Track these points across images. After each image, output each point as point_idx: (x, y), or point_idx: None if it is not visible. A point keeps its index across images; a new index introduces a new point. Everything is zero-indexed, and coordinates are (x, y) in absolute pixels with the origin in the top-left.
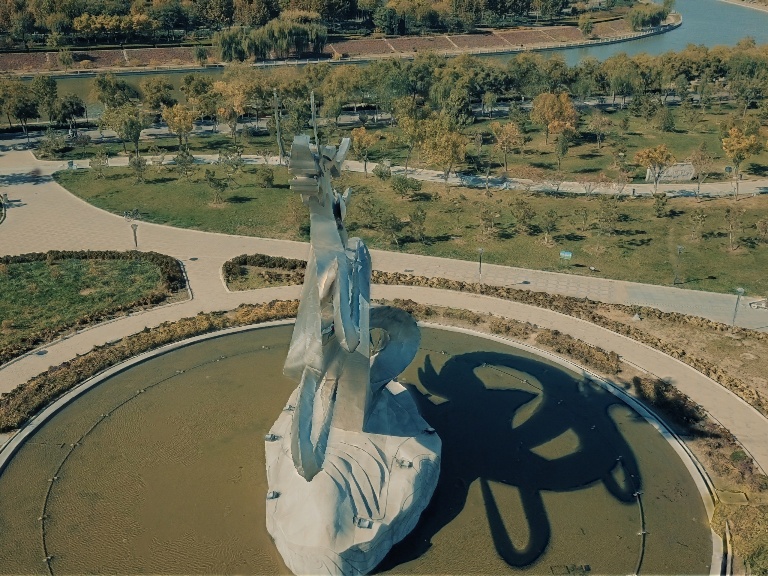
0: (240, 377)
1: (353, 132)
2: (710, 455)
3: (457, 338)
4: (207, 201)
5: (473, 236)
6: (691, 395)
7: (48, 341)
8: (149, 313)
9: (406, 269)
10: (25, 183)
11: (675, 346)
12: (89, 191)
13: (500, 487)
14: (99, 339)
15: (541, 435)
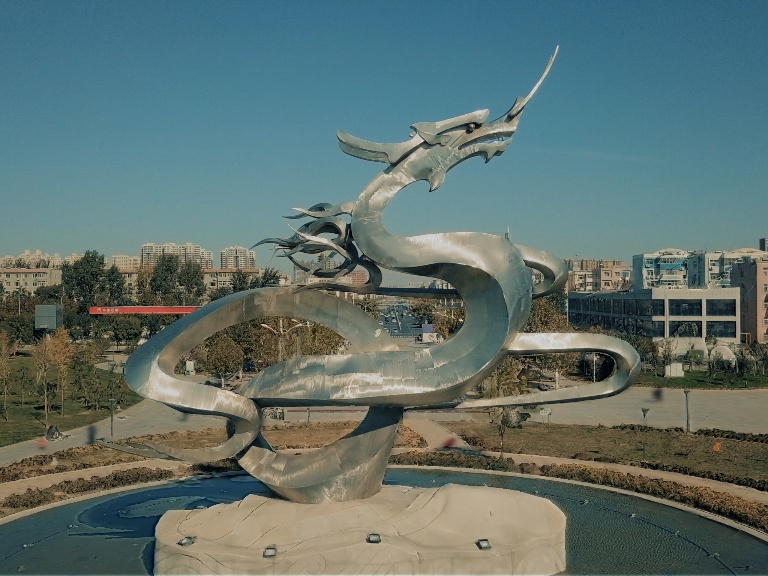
0: None
1: None
2: None
3: (31, 522)
4: None
5: None
6: None
7: None
8: None
9: None
10: None
11: None
12: None
13: None
14: None
15: None
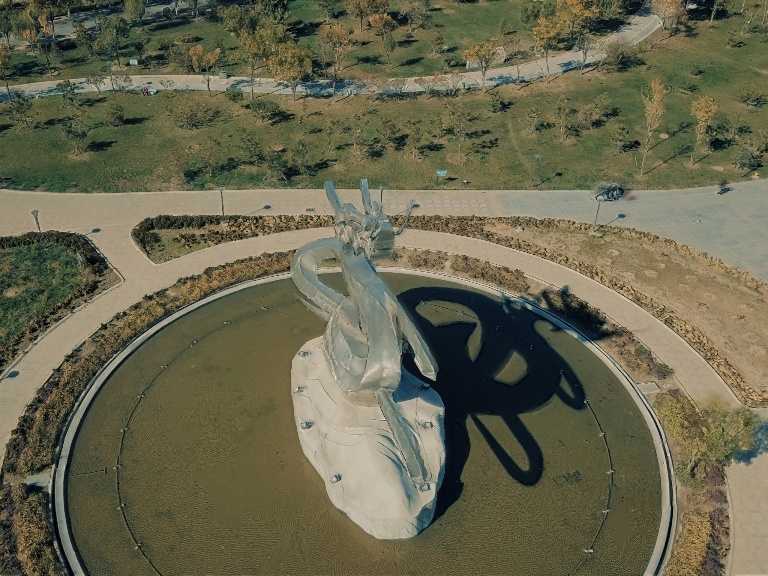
0: (222, 360)
1: (191, 52)
2: (622, 354)
3: (387, 278)
4: (66, 153)
5: (348, 159)
6: (588, 300)
7: (10, 359)
8: (92, 305)
9: (307, 208)
10: None
11: (558, 253)
12: None
13: (488, 419)
14: (62, 346)
15: (495, 363)
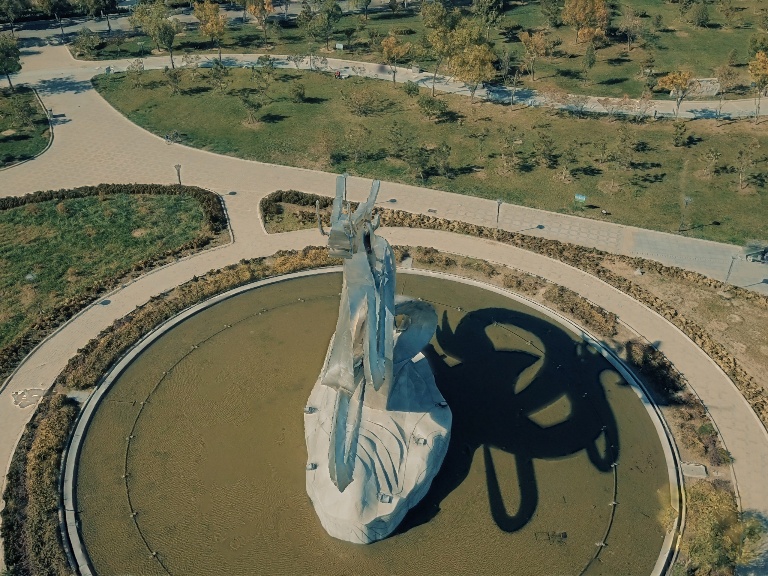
0: (280, 332)
1: (383, 43)
2: (682, 427)
3: (473, 292)
4: (242, 120)
5: (495, 168)
6: (675, 362)
7: (110, 289)
8: (196, 258)
9: (430, 209)
10: (66, 91)
11: (669, 305)
12: (128, 104)
13: (500, 455)
14: (154, 288)
15: (539, 401)
